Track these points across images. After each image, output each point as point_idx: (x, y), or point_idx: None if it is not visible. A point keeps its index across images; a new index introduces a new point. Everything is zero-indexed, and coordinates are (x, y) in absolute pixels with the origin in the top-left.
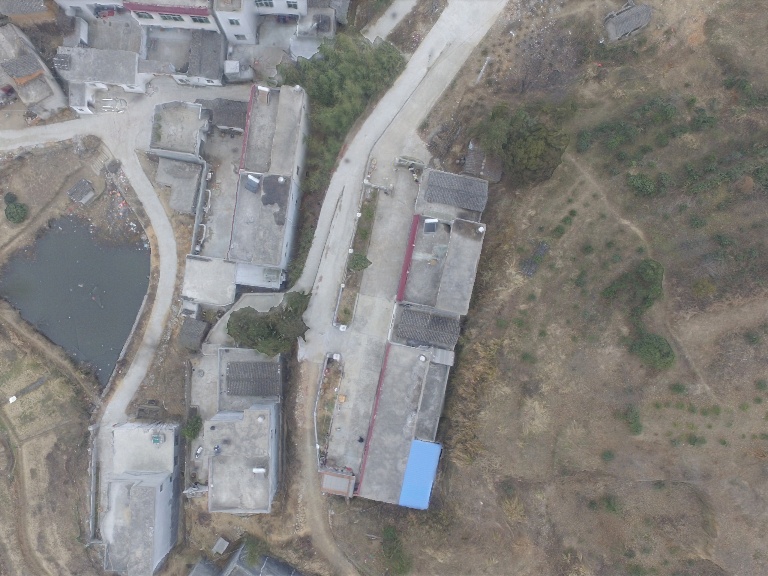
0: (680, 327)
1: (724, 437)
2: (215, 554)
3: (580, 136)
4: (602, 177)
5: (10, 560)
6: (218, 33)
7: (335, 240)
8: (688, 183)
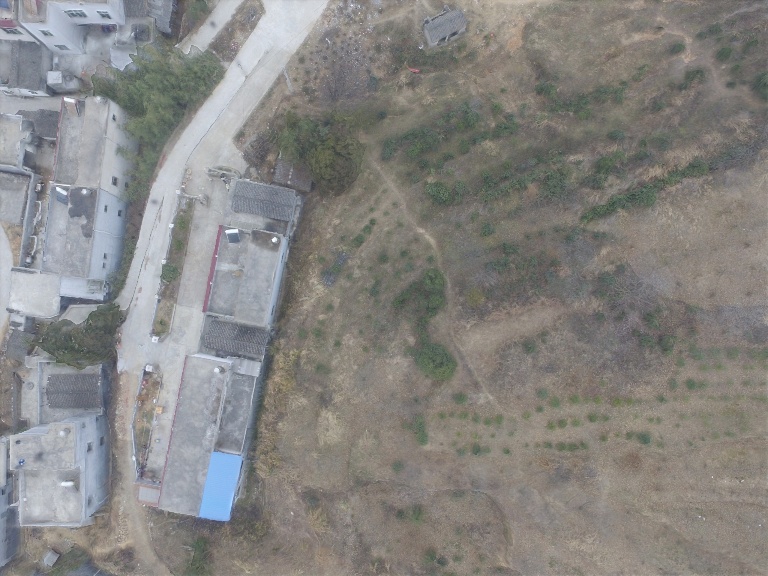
0: (462, 336)
1: (508, 446)
2: (47, 566)
3: (385, 144)
4: (404, 185)
5: None
6: (37, 44)
7: (155, 251)
8: (483, 190)
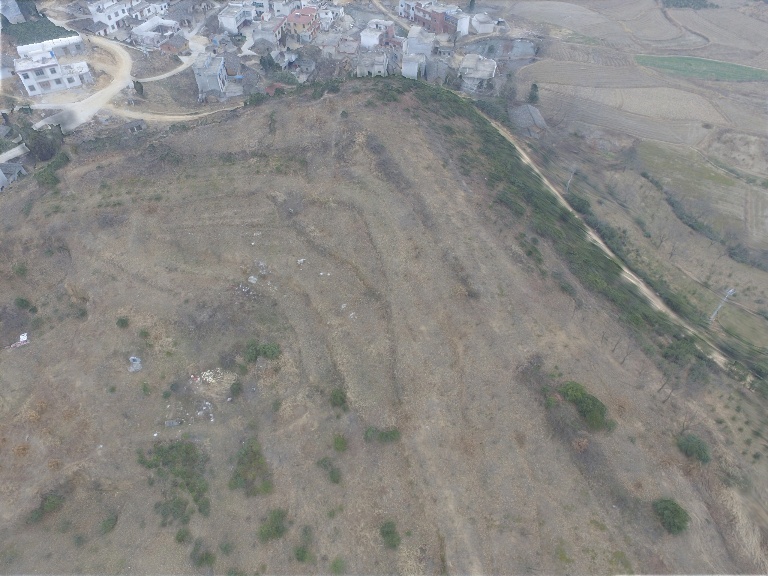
0: (68, 173)
1: (76, 210)
2: None
3: None
4: None
5: None
6: None
7: None
8: None
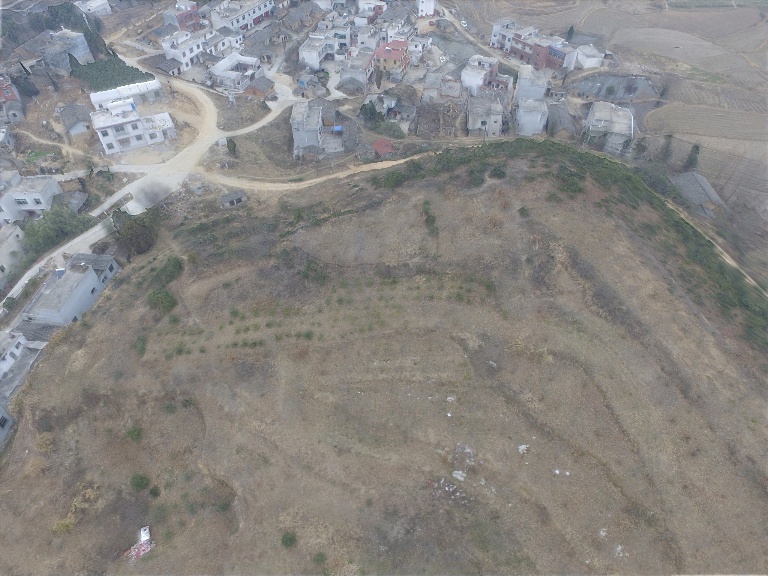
0: (185, 289)
1: (205, 350)
2: None
3: None
4: None
5: None
6: None
7: None
8: None
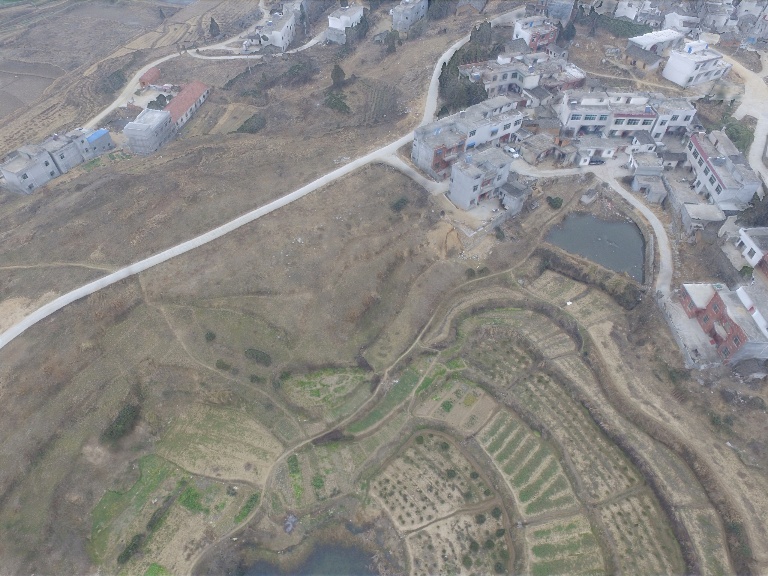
0: None
1: None
2: None
3: None
4: None
5: (604, 413)
6: (649, 132)
7: None
8: None
